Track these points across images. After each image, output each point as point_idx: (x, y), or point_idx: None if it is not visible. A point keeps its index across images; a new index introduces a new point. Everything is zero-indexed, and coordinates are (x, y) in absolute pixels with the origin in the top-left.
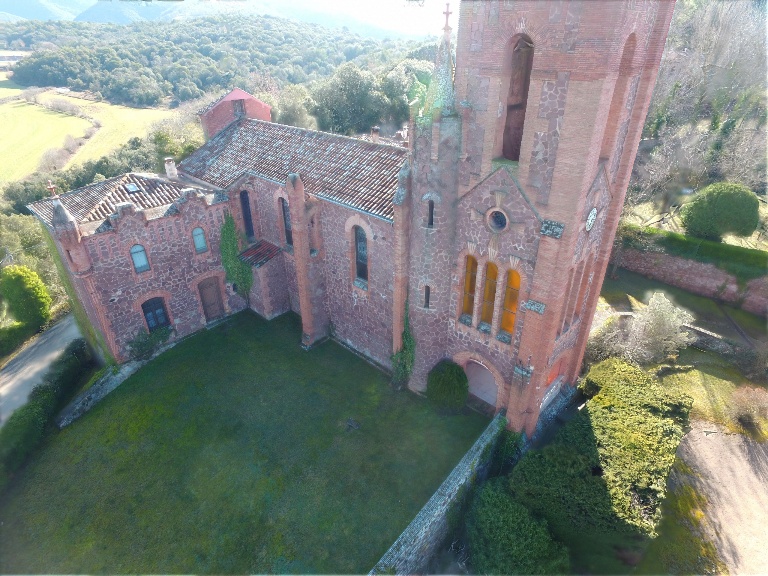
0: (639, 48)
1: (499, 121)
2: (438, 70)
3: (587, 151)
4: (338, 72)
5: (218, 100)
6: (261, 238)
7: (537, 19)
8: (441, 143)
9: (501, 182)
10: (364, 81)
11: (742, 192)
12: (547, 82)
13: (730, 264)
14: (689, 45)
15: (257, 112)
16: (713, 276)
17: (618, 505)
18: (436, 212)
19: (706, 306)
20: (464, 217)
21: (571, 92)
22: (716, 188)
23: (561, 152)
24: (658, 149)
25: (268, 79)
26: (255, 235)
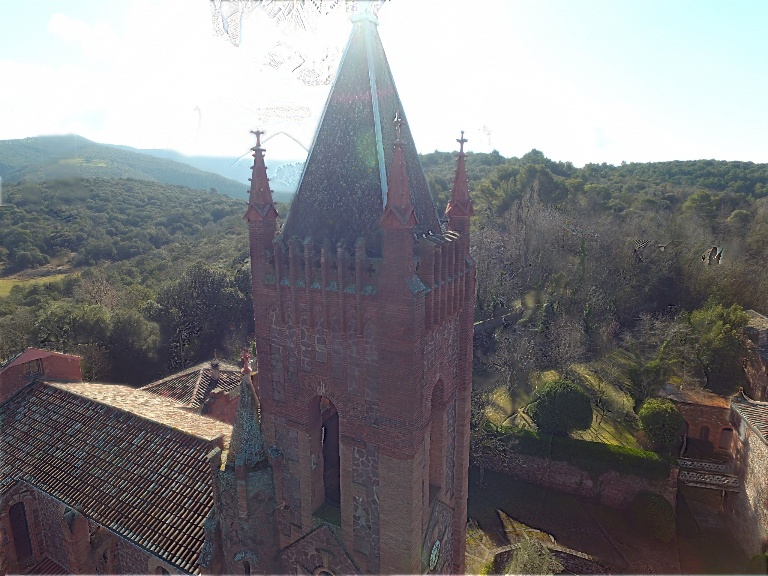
0: (448, 382)
1: (315, 472)
2: (241, 414)
3: (410, 528)
4: (187, 270)
5: (2, 367)
6: (44, 555)
7: (336, 388)
8: (250, 498)
9: (325, 541)
10: (216, 278)
11: (573, 391)
12: (357, 449)
13: (581, 460)
14: (504, 245)
15: (60, 368)
16: (570, 473)
17: None
18: (254, 573)
19: (571, 507)
20: (290, 570)
21: (382, 465)
22: (552, 387)
23: (384, 523)
24: (499, 331)
25: (103, 284)
26: (34, 554)
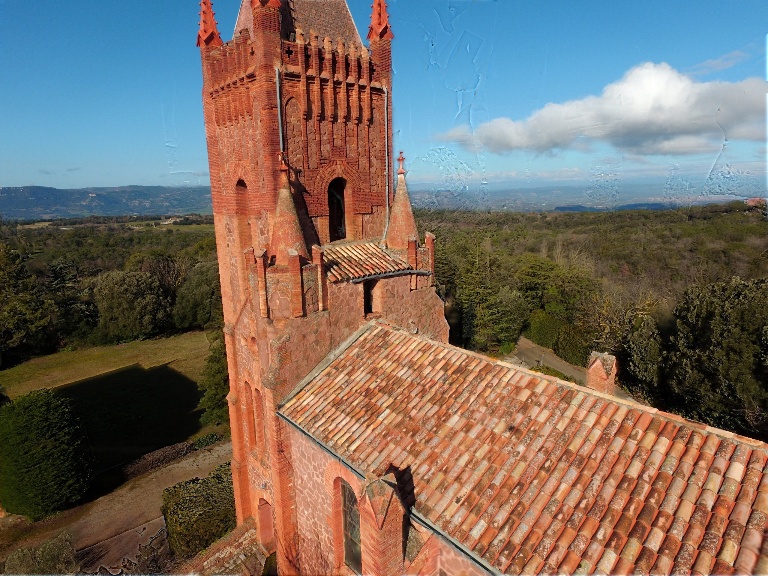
0: None
1: None
2: None
3: None
4: None
5: None
6: None
7: None
8: None
9: None
10: None
11: None
12: None
13: None
14: None
15: None
16: None
17: None
18: None
19: None
20: None
21: None
22: None
23: None
24: None
25: None
26: None
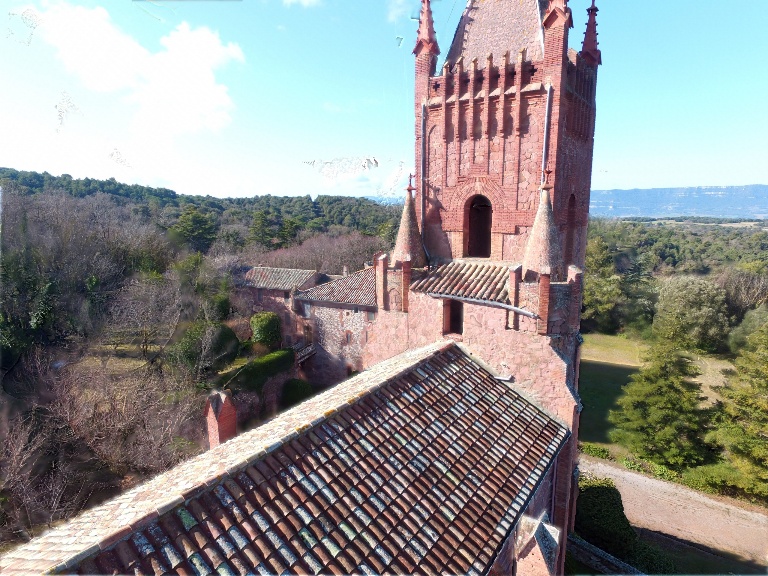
0: None
1: None
2: None
3: None
4: None
5: None
6: None
7: None
8: None
9: None
10: None
11: (223, 325)
12: None
13: (249, 383)
14: None
15: None
16: None
17: (607, 485)
18: None
19: None
20: None
21: (582, 234)
22: None
23: None
24: (8, 332)
25: None
26: None
